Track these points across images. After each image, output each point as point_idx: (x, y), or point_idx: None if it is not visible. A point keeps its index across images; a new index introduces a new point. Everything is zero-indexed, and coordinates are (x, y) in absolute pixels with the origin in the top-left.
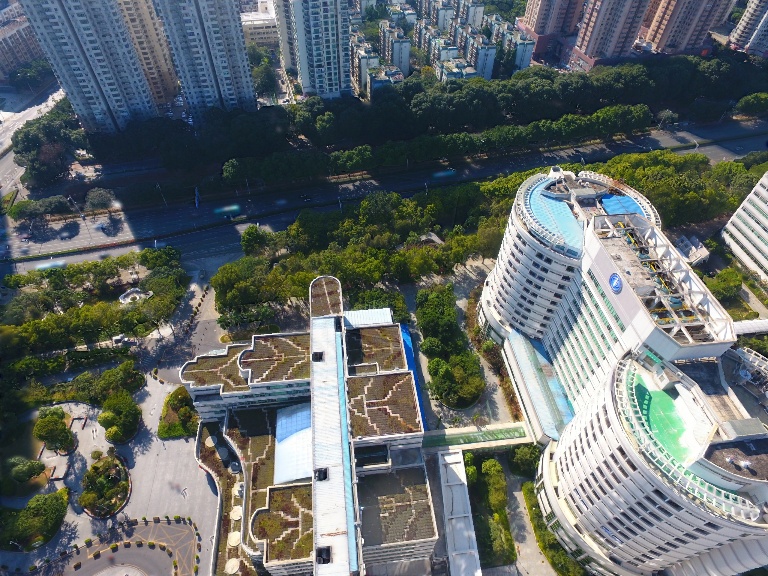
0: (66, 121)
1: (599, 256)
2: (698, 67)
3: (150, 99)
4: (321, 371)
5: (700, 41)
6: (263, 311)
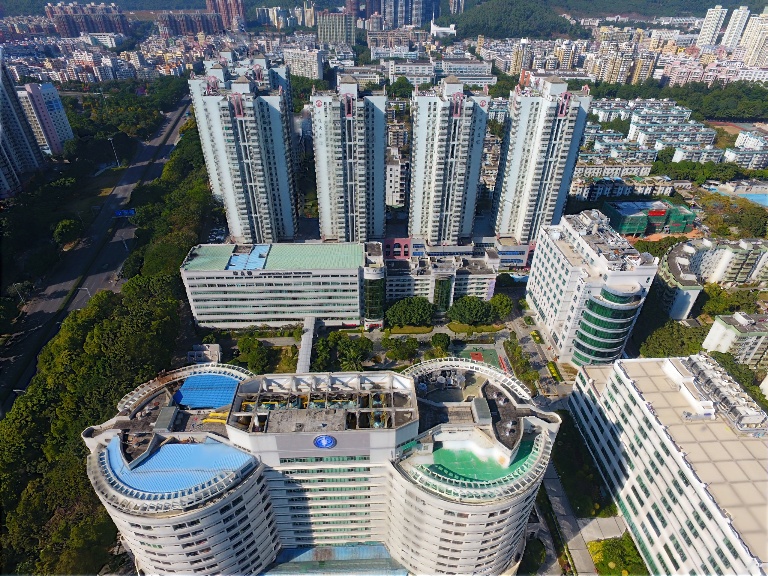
0: None
1: (282, 443)
2: None
3: None
4: None
5: None
6: None
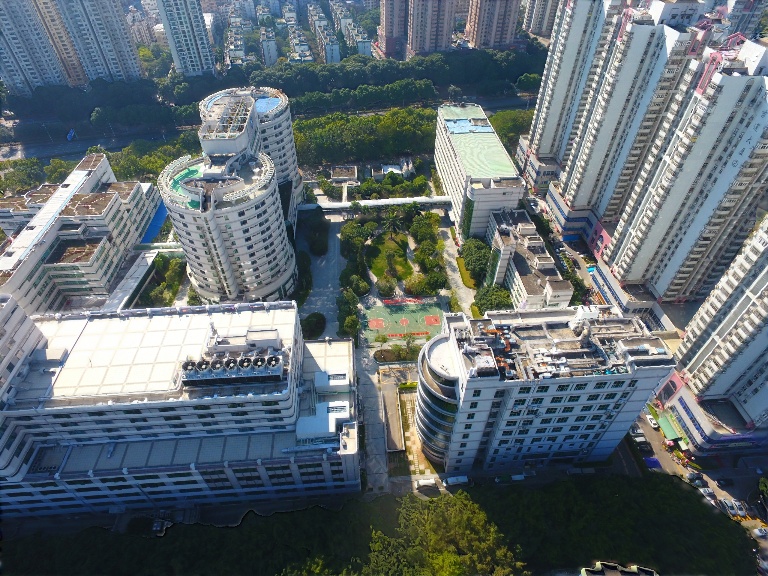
0: (1, 91)
1: None
2: (493, 57)
3: (61, 75)
4: (62, 191)
5: (505, 40)
6: None
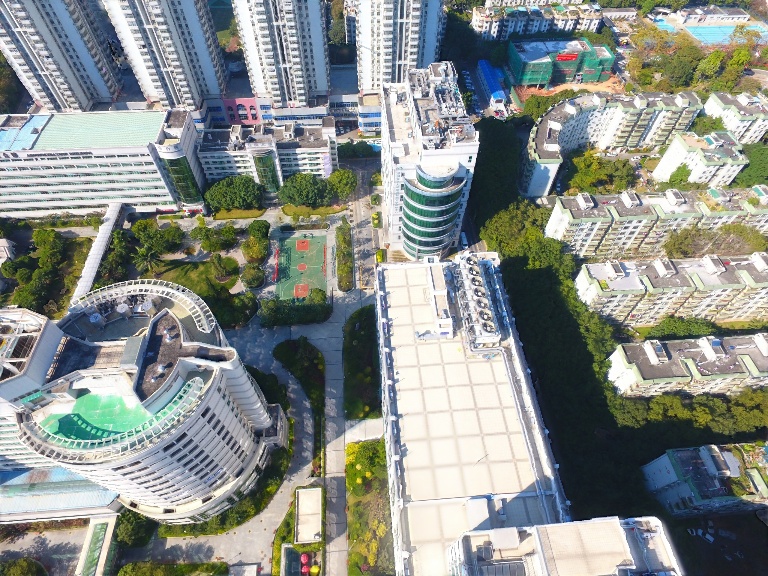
0: None
1: None
2: None
3: None
4: None
5: None
6: None
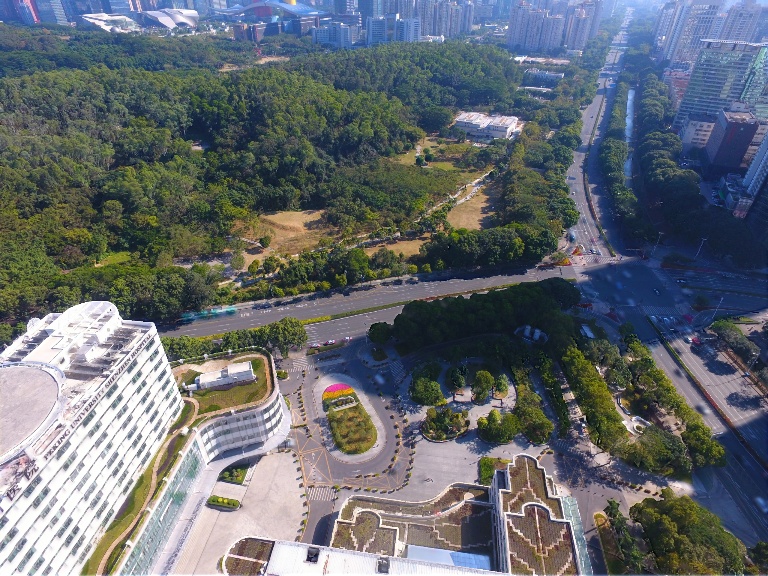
0: None
1: None
2: None
3: None
4: None
5: None
6: (633, 553)
